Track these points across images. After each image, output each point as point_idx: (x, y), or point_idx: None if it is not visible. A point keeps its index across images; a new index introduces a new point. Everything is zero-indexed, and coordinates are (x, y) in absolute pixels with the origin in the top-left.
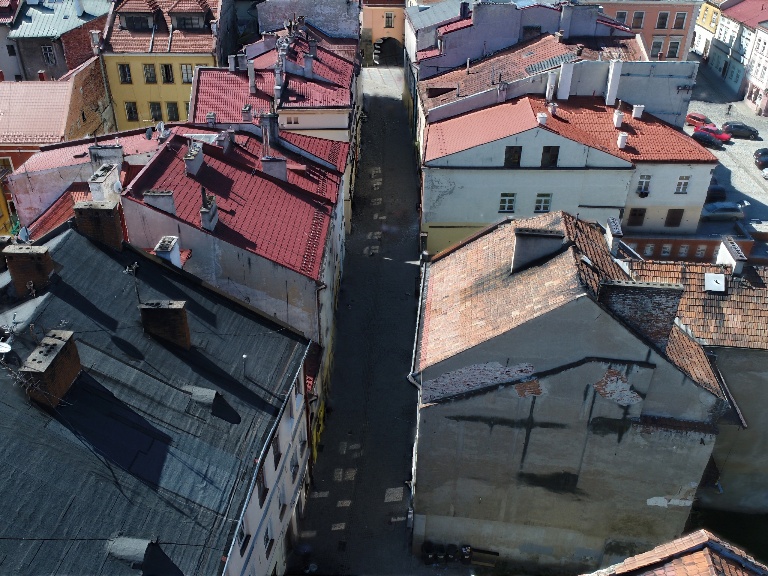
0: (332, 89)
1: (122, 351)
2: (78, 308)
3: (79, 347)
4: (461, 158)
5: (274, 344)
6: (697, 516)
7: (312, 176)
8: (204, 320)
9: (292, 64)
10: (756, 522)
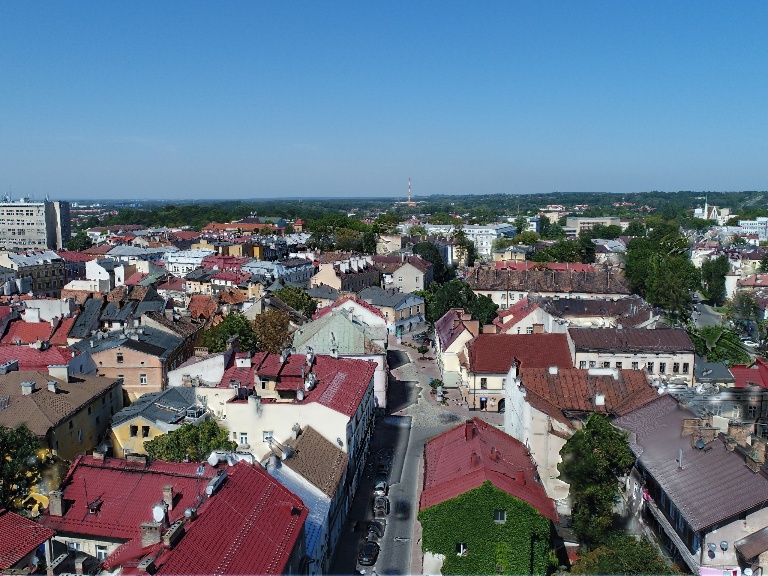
0: None
1: None
2: None
3: None
4: None
5: None
6: None
7: None
8: None
9: None
10: None
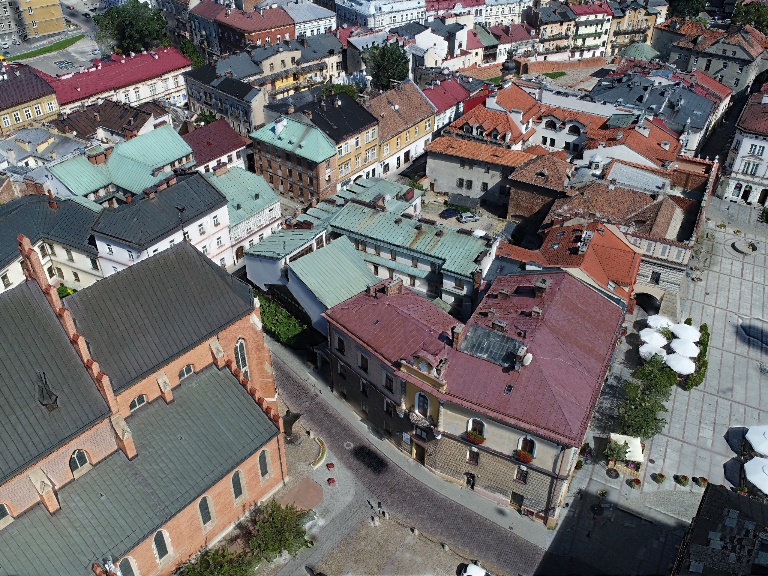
0: None
1: None
2: None
3: None
4: None
5: None
6: None
7: None
8: None
9: None
10: None
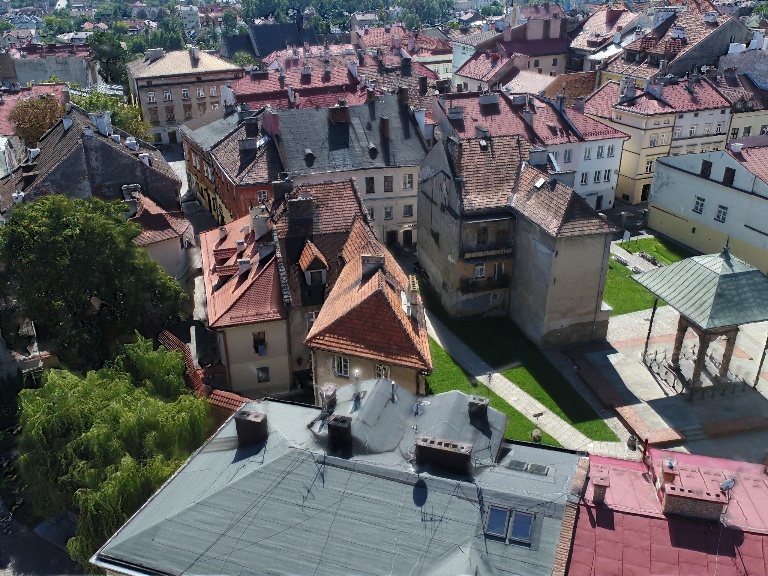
0: (661, 106)
1: (367, 126)
2: (370, 111)
3: (357, 118)
4: (676, 160)
5: (419, 156)
6: (464, 280)
7: (558, 132)
8: (404, 136)
9: (652, 87)
10: (523, 339)
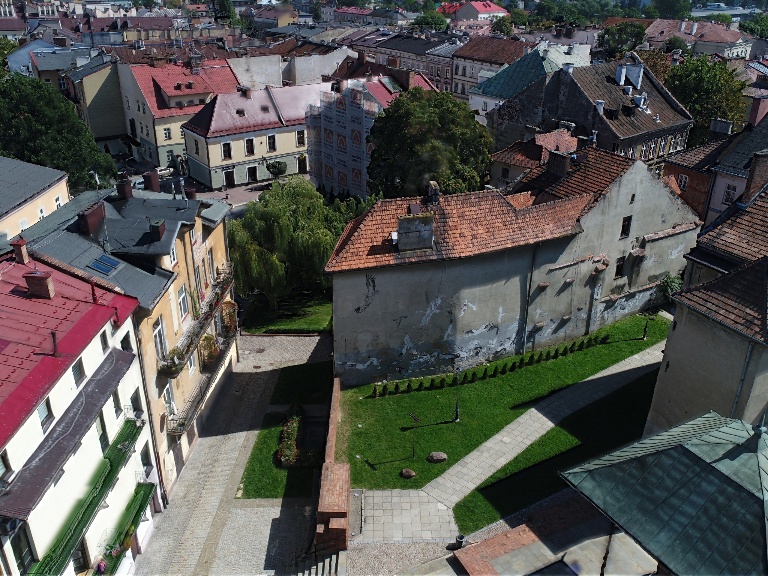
0: None
1: None
2: None
3: None
4: None
5: None
6: None
7: None
8: None
9: None
10: None
